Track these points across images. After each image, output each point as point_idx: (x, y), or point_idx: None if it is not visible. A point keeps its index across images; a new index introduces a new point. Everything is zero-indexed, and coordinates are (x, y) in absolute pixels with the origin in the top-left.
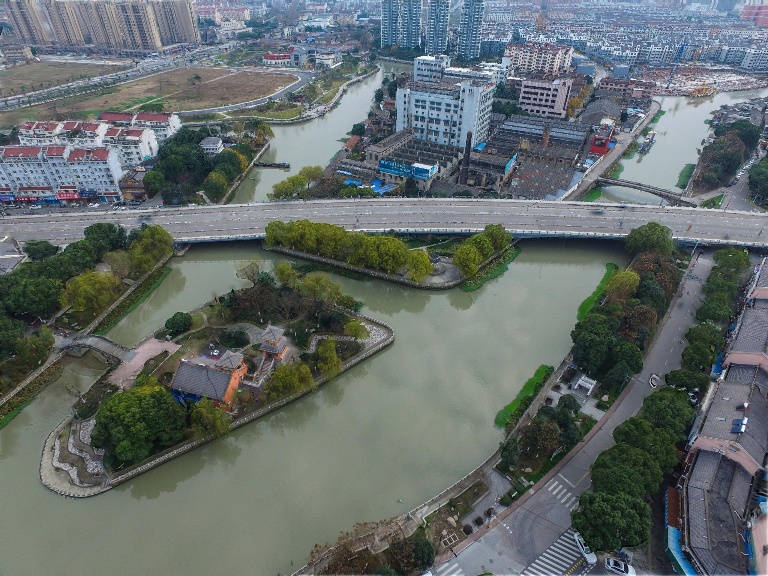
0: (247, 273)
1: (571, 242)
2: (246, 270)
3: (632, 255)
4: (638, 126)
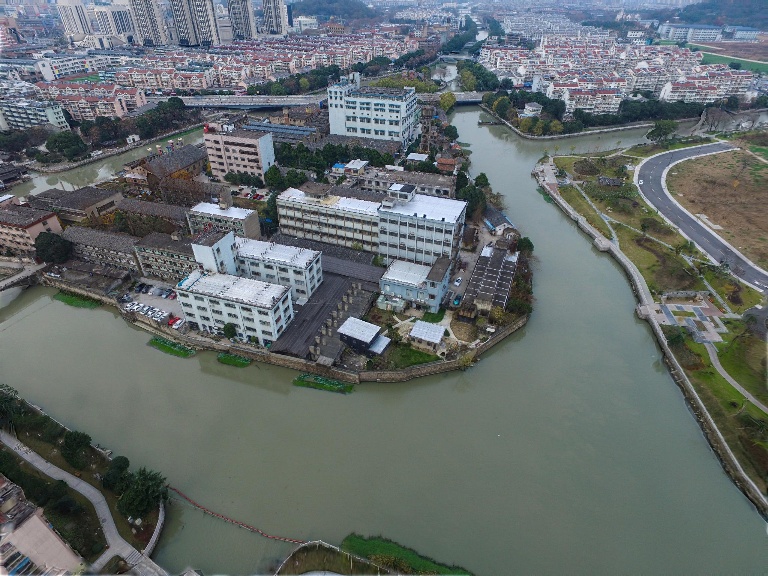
0: None
1: None
2: None
3: None
4: None
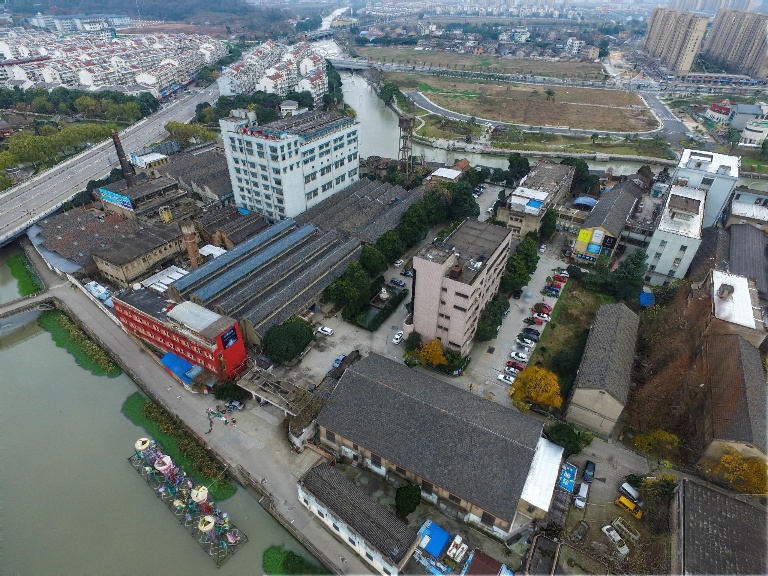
0: None
1: None
2: None
3: None
4: (383, 575)
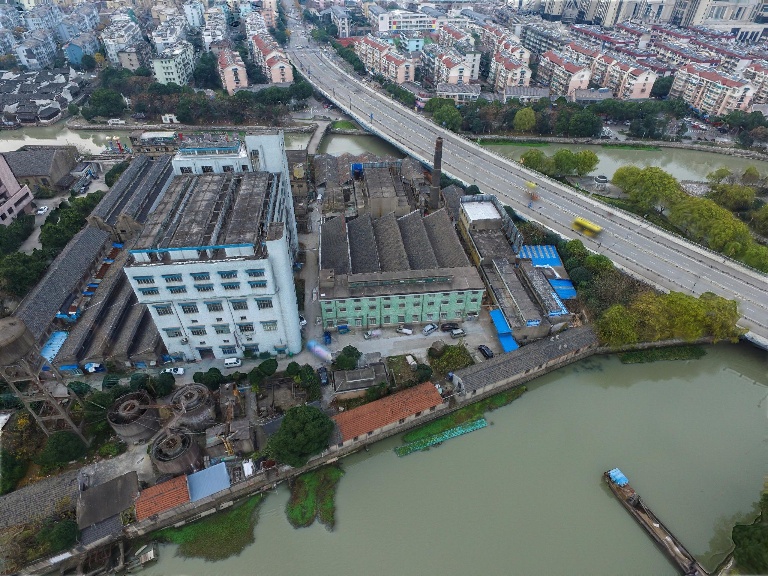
0: None
1: None
2: None
3: None
4: None
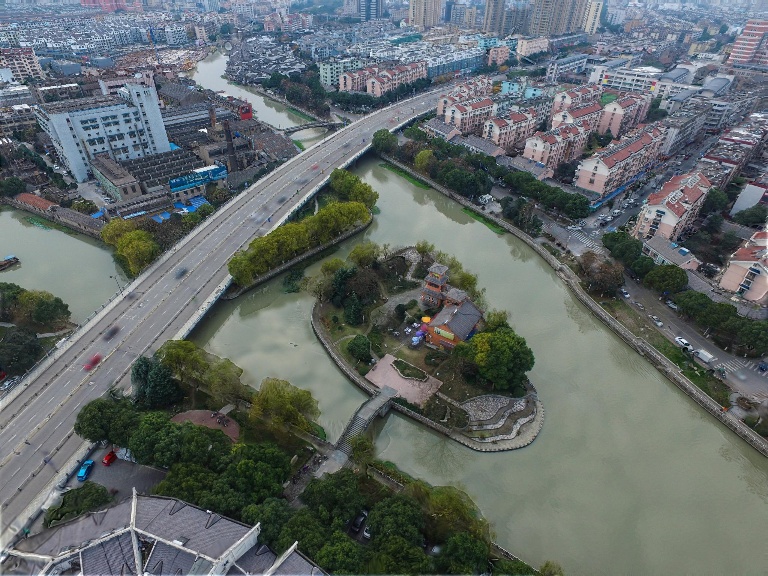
0: (314, 291)
1: (356, 164)
2: (314, 288)
3: (379, 156)
4: None
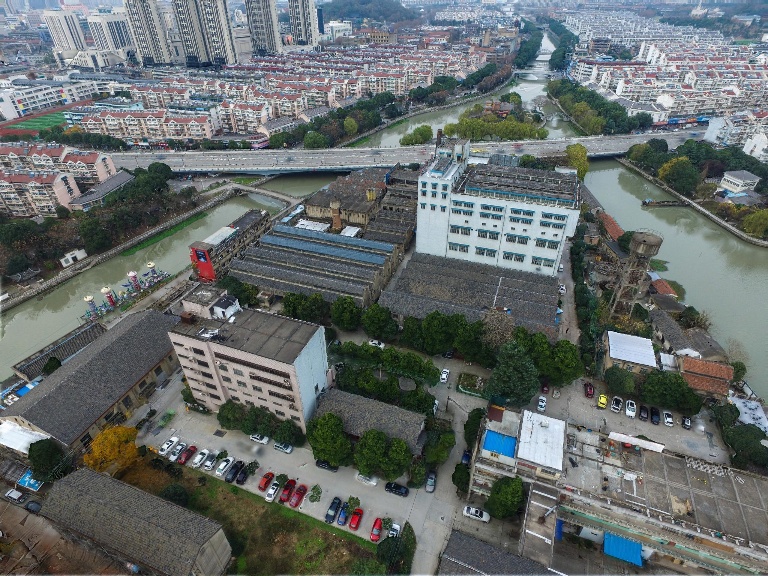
0: None
1: None
2: None
3: None
4: None
